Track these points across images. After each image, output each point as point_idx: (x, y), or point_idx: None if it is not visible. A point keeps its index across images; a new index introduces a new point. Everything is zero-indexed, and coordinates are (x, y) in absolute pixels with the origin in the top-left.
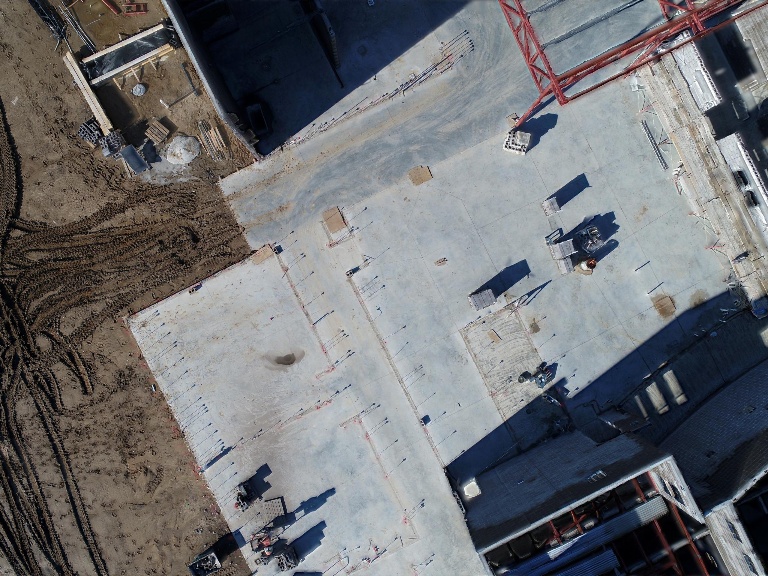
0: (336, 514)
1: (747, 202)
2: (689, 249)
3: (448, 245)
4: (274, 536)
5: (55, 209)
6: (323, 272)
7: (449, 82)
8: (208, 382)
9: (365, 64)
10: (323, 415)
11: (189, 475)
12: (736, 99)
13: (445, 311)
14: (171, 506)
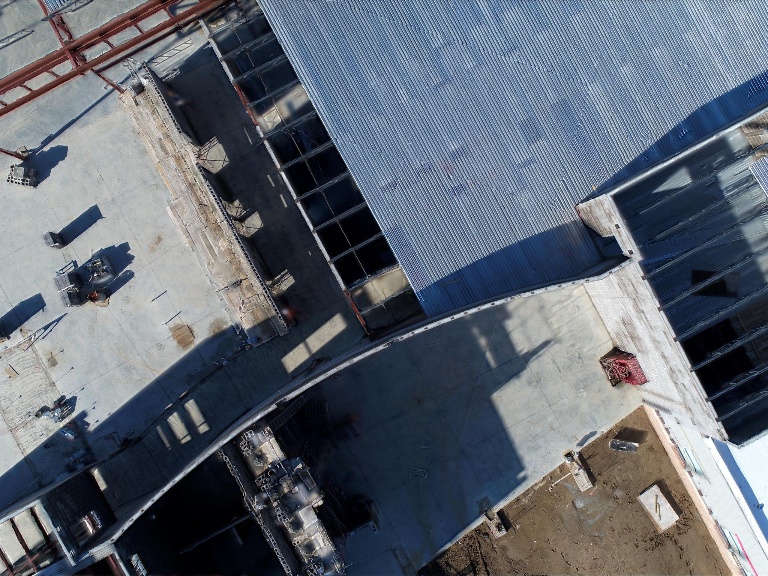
0: None
1: (208, 233)
2: (206, 277)
3: None
4: None
5: None
6: None
7: None
8: None
9: None
10: None
11: None
12: (248, 125)
13: None
14: None
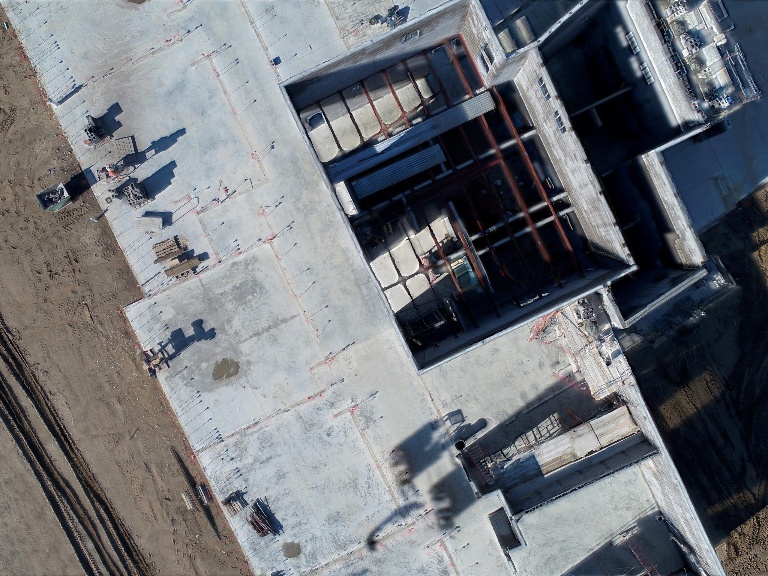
0: (186, 154)
1: None
2: None
3: None
4: (125, 175)
5: None
6: None
7: None
8: (60, 19)
9: None
10: (174, 55)
11: (42, 115)
12: None
13: None
14: (24, 145)
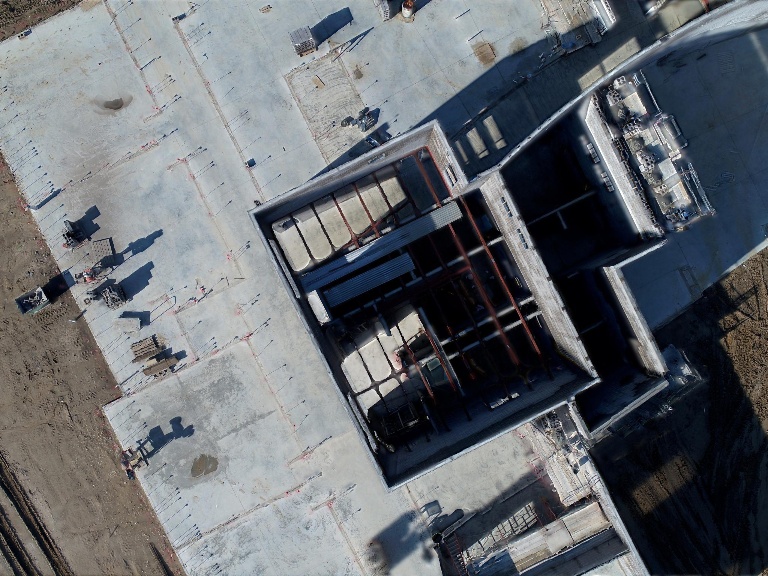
0: (163, 255)
1: None
2: None
3: None
4: (103, 276)
5: None
6: (150, 19)
7: None
8: (38, 126)
9: None
10: (151, 158)
11: (21, 218)
12: None
13: (270, 57)
14: (3, 248)
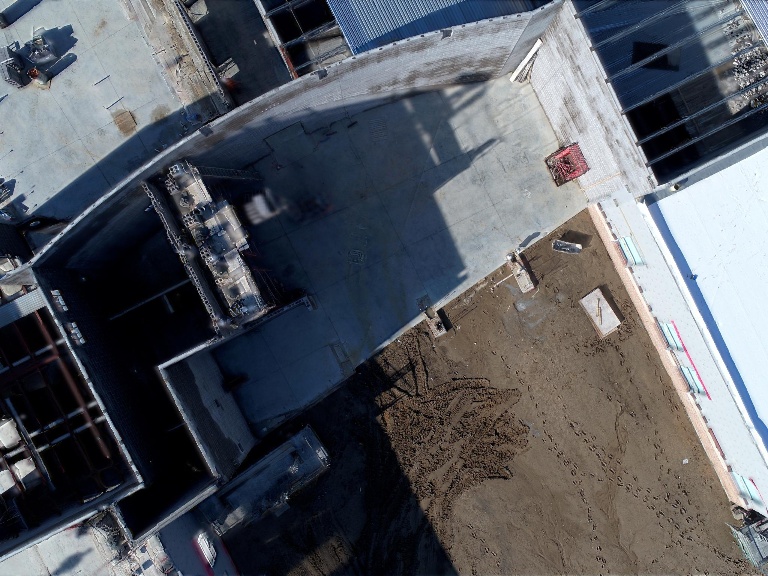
0: None
1: None
2: (149, 63)
3: None
4: None
5: None
6: None
7: None
8: None
9: None
10: None
11: None
12: None
13: None
14: None
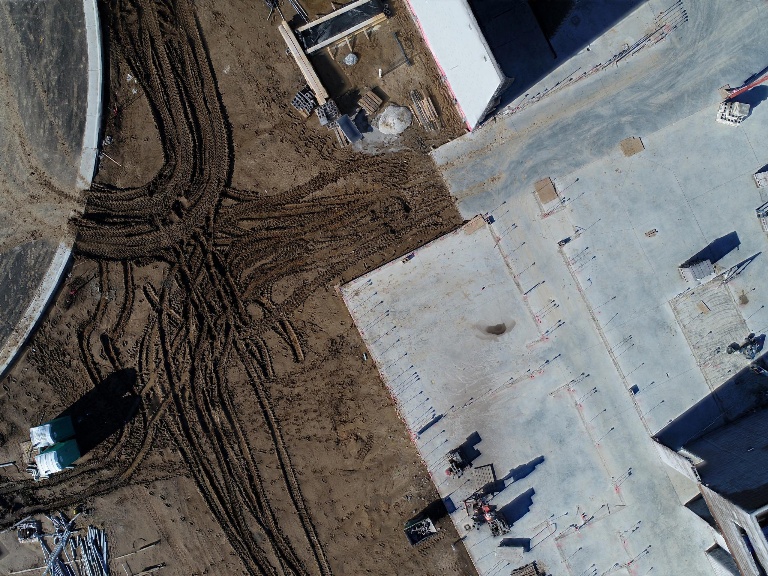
0: (544, 481)
1: None
2: None
3: (659, 216)
4: None
5: (267, 178)
6: (534, 243)
7: (662, 53)
8: (420, 351)
9: (579, 34)
10: (533, 384)
11: (399, 442)
12: None
13: (655, 282)
14: (381, 472)
